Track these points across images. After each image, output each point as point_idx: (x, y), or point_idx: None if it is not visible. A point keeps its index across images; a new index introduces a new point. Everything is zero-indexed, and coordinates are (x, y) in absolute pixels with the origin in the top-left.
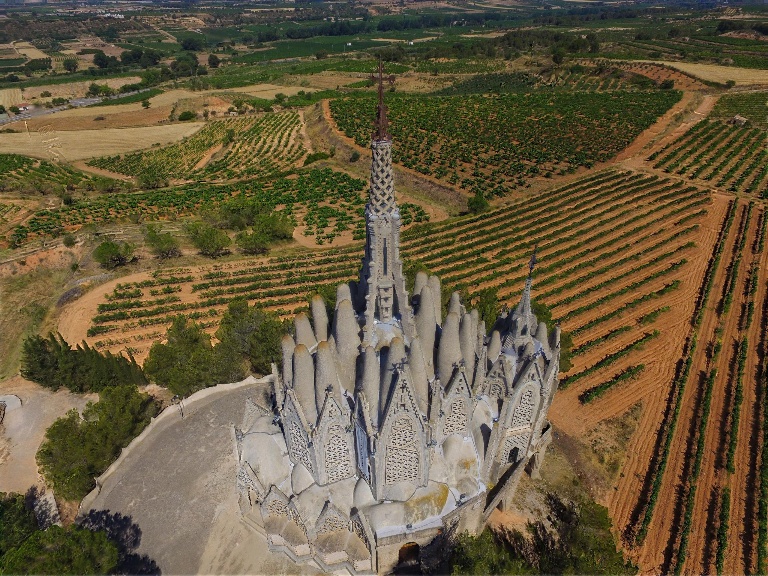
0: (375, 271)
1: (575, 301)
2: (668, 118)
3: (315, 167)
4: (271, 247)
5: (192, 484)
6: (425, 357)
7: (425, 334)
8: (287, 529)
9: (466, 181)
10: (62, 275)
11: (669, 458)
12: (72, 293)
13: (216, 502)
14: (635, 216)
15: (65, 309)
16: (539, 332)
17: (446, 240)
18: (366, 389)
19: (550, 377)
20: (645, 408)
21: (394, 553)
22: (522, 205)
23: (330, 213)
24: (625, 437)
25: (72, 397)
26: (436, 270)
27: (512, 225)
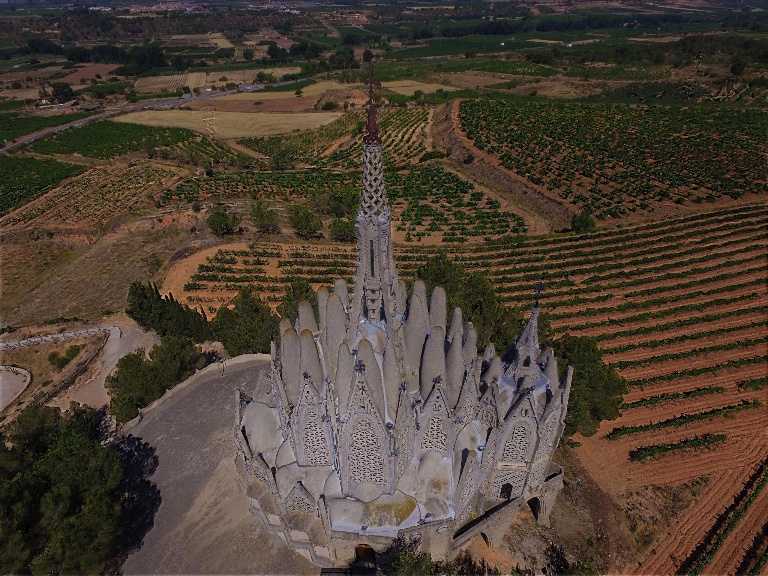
0: (361, 271)
1: (664, 346)
2: None
3: (428, 165)
4: None
5: (209, 435)
6: (410, 366)
7: (411, 343)
8: (264, 497)
9: (579, 196)
10: None
11: (723, 550)
12: (184, 251)
13: (223, 456)
14: None
15: (175, 264)
16: (548, 367)
17: (534, 256)
18: (337, 384)
19: (552, 418)
20: (712, 485)
21: (349, 549)
22: (635, 230)
23: (428, 212)
24: (673, 511)
25: (157, 339)
26: (514, 285)
27: (616, 250)
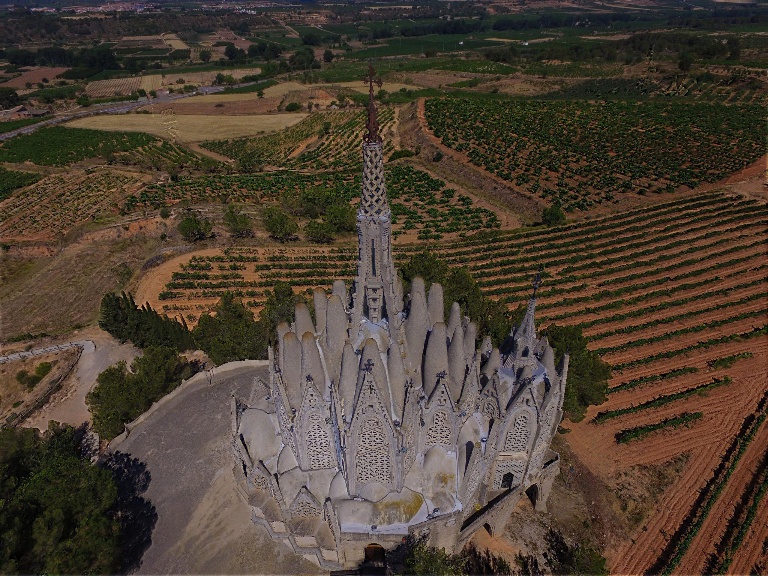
0: (362, 271)
1: (638, 331)
2: None
3: (398, 164)
4: (337, 238)
5: (202, 446)
6: (412, 363)
7: (413, 340)
8: (267, 504)
9: (547, 190)
10: (155, 243)
11: (708, 522)
12: (155, 259)
13: (218, 466)
14: (735, 246)
15: (147, 273)
16: (545, 356)
17: (510, 250)
18: (342, 385)
19: (551, 406)
20: (693, 461)
21: (359, 550)
22: (603, 221)
23: (401, 210)
24: (659, 488)
25: (134, 351)
26: (492, 279)
27: (587, 241)
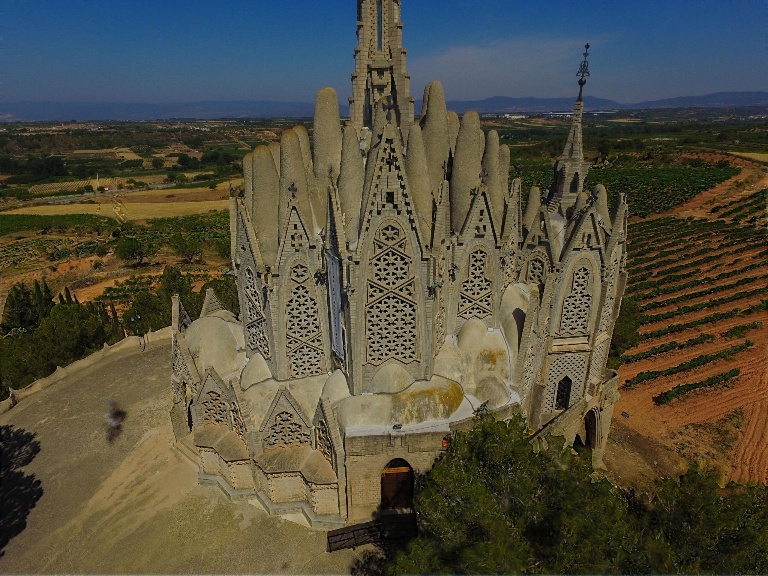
0: (365, 36)
1: None
2: (728, 185)
3: None
4: None
5: (126, 408)
6: (433, 190)
7: (433, 153)
8: (224, 440)
9: None
10: None
11: None
12: (85, 280)
13: (148, 427)
14: None
15: (73, 293)
16: None
17: None
18: (342, 192)
19: (614, 258)
20: (748, 417)
21: (373, 479)
22: None
23: None
24: (725, 444)
25: None
26: None
27: None
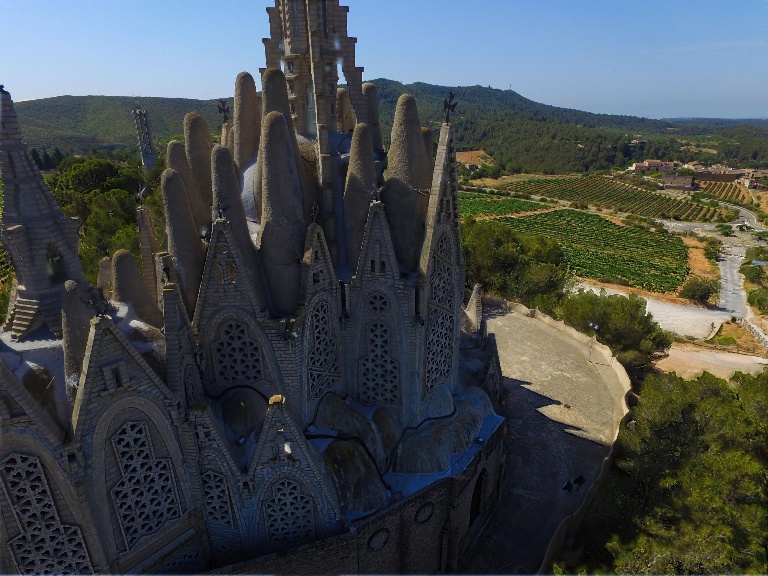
0: None
1: None
2: None
3: None
4: None
5: None
6: None
7: None
8: None
9: None
10: None
11: None
12: None
13: None
14: None
15: None
16: None
17: None
18: None
19: None
20: None
21: None
22: None
23: None
24: None
25: None
26: None
27: None
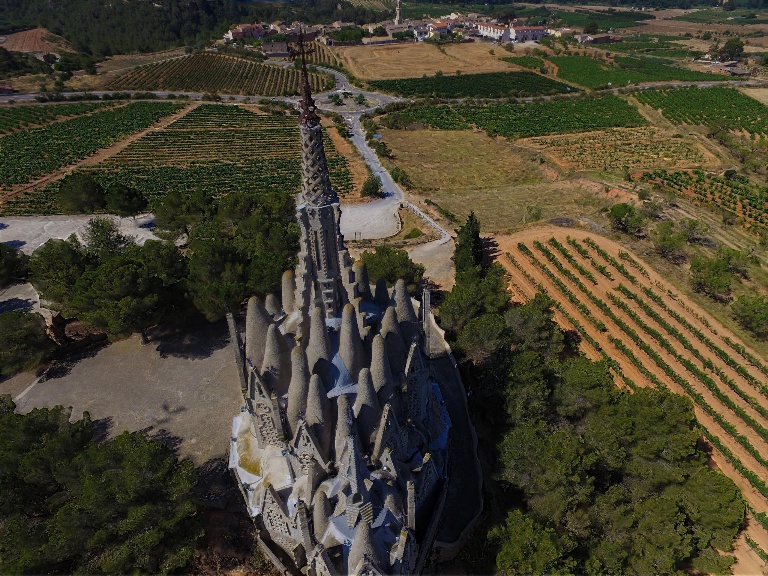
0: None
1: None
2: None
3: None
4: None
5: None
6: None
7: None
8: None
9: None
10: None
11: None
12: (564, 221)
13: None
14: None
15: (545, 226)
16: None
17: None
18: None
19: (324, 572)
20: None
21: None
22: None
23: None
24: None
25: (451, 262)
26: None
27: None
